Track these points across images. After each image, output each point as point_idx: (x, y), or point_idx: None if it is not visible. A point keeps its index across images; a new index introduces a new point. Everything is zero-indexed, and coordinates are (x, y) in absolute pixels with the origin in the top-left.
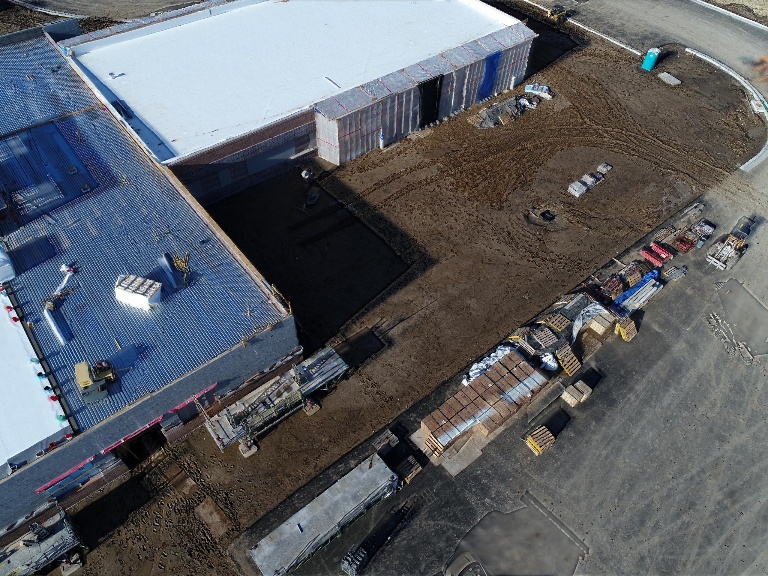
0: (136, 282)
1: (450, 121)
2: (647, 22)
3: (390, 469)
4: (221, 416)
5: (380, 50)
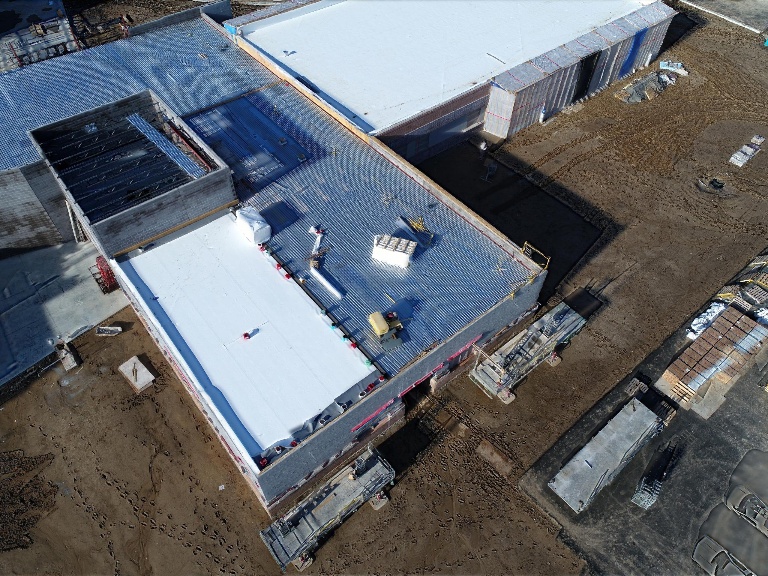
0: (393, 241)
1: (597, 96)
2: (756, 2)
3: (653, 412)
4: (485, 365)
5: (530, 28)
